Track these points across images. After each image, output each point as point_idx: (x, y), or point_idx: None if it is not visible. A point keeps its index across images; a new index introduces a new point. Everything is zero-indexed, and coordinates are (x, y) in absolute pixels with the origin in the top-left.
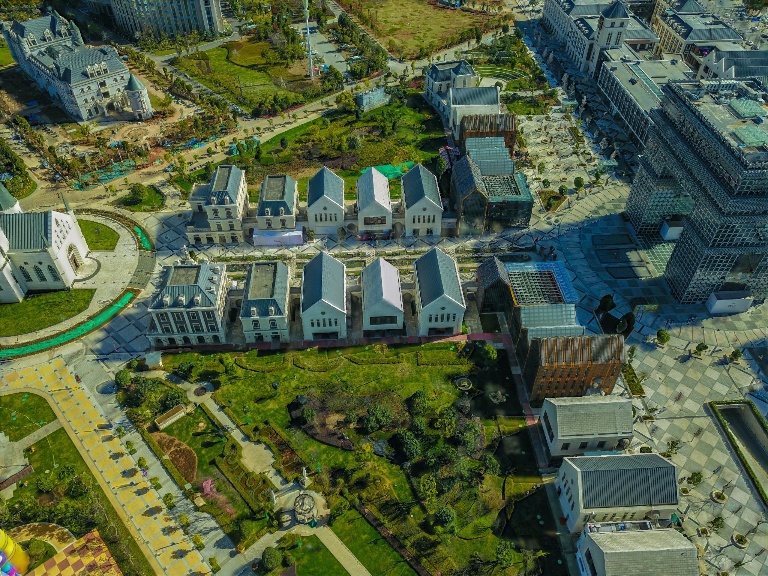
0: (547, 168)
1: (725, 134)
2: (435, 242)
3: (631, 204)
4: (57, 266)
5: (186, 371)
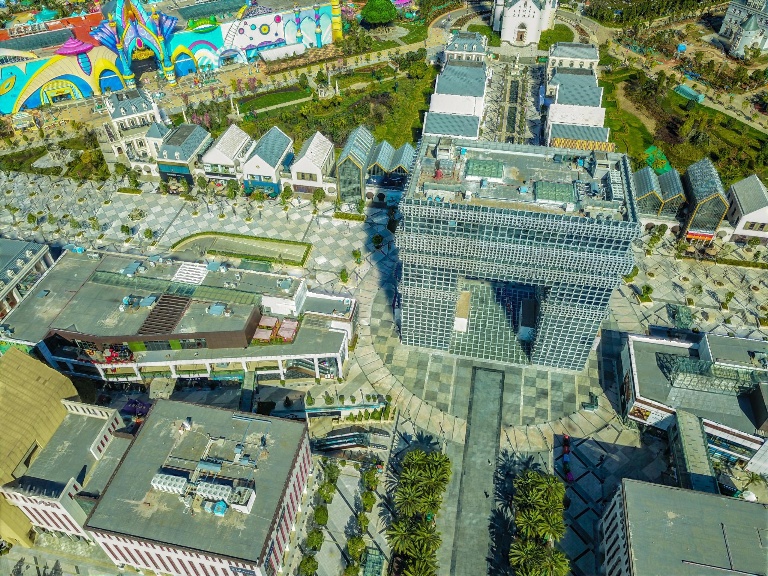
0: (679, 269)
1: (498, 160)
2: None
3: None
4: (503, 21)
5: None
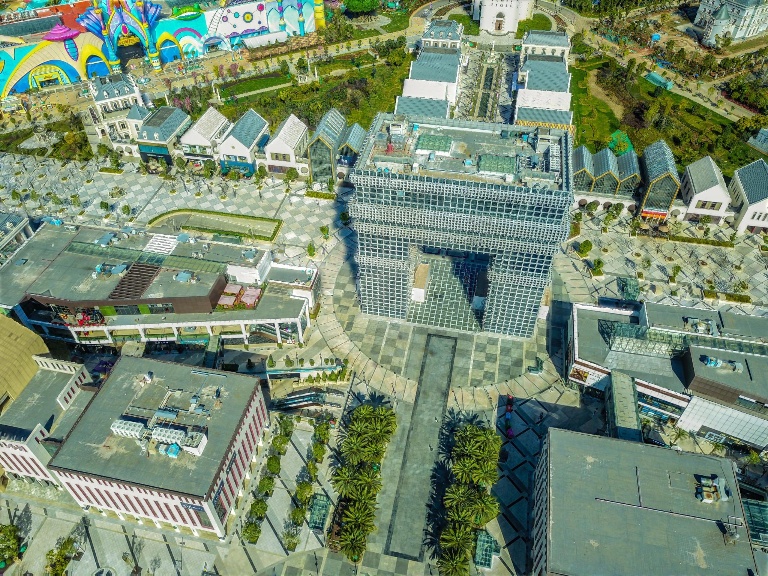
0: (632, 246)
1: (449, 135)
2: None
3: None
4: None
5: None
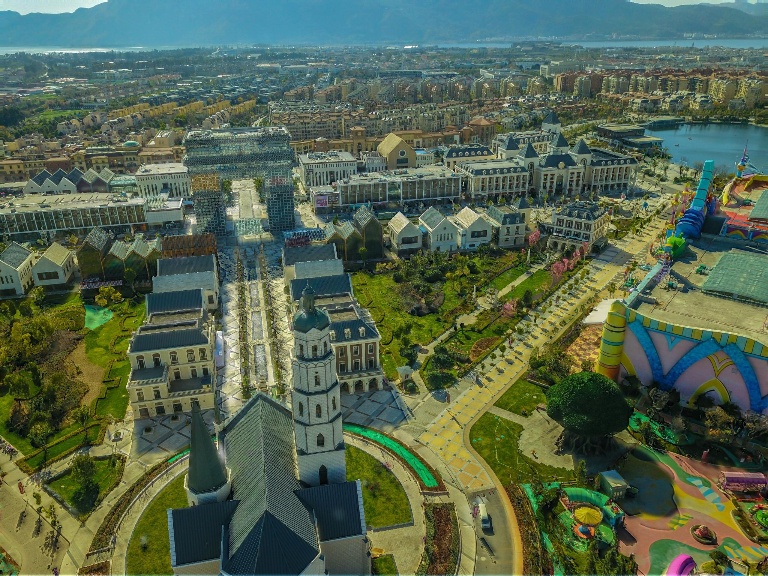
0: None
1: None
2: (228, 288)
3: (205, 227)
4: None
5: (414, 350)
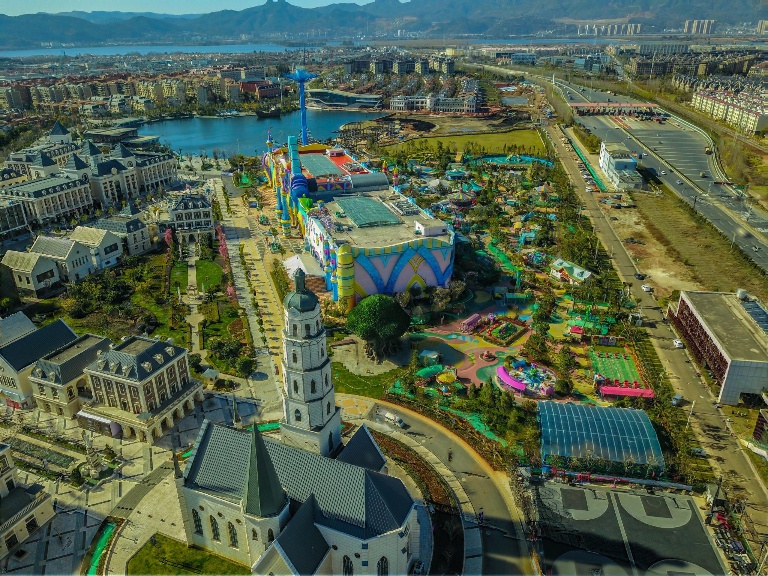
0: None
1: None
2: None
3: None
4: None
5: (195, 356)
